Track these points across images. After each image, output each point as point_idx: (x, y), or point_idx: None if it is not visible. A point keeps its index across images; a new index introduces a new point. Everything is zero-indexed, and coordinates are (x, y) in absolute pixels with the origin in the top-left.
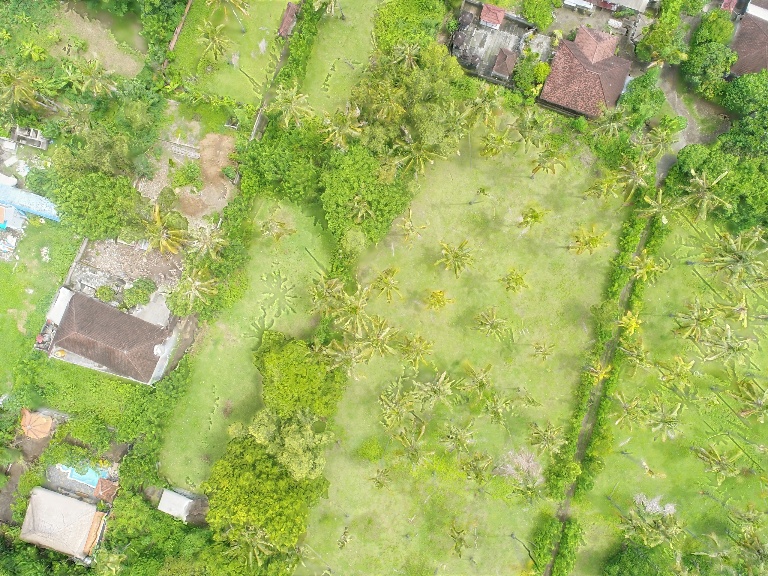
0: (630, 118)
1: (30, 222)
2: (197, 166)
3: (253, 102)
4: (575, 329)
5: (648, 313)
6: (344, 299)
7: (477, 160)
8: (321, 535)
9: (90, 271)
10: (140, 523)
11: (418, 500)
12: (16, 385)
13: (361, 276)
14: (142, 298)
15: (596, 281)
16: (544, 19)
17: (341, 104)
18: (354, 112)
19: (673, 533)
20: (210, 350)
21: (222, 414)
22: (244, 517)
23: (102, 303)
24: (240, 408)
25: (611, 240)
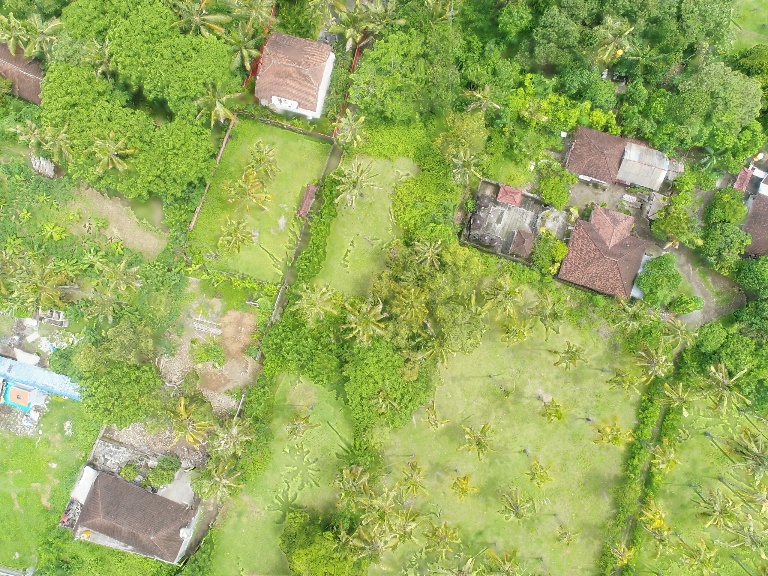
0: (647, 299)
1: (53, 399)
2: None
3: (273, 278)
4: (596, 499)
5: (668, 483)
6: (372, 503)
7: (496, 334)
8: None
9: (114, 447)
10: None
11: None
12: (41, 563)
13: (383, 449)
14: (167, 480)
15: (616, 451)
16: (560, 200)
17: (361, 280)
18: (377, 309)
19: None
20: (234, 522)
21: None
22: None
23: (127, 483)
24: None
25: (630, 411)
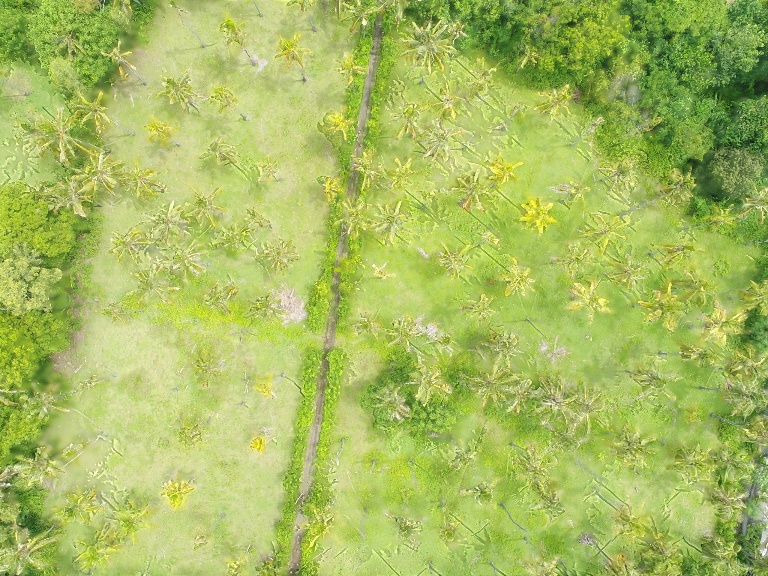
0: None
1: None
2: None
3: None
4: (320, 160)
5: (389, 136)
6: None
7: (206, 3)
8: (91, 399)
9: None
10: None
11: (184, 350)
12: None
13: (102, 129)
14: None
15: (335, 110)
16: None
17: None
18: None
19: (405, 328)
20: None
21: None
22: None
23: None
24: None
25: None
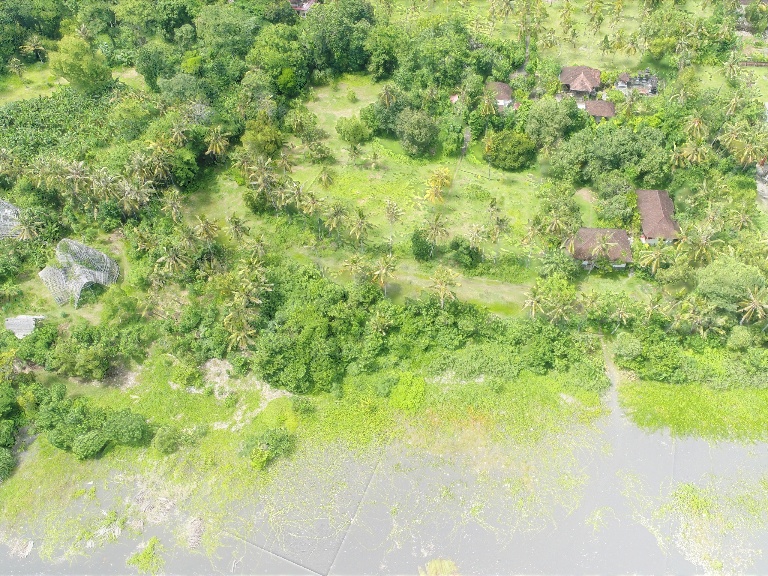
0: None
1: None
2: None
3: None
4: None
5: None
6: None
7: None
8: None
9: None
10: None
11: None
12: None
13: None
14: (750, 4)
15: None
16: None
17: None
18: None
19: None
20: None
21: None
22: None
23: None
24: None
25: None
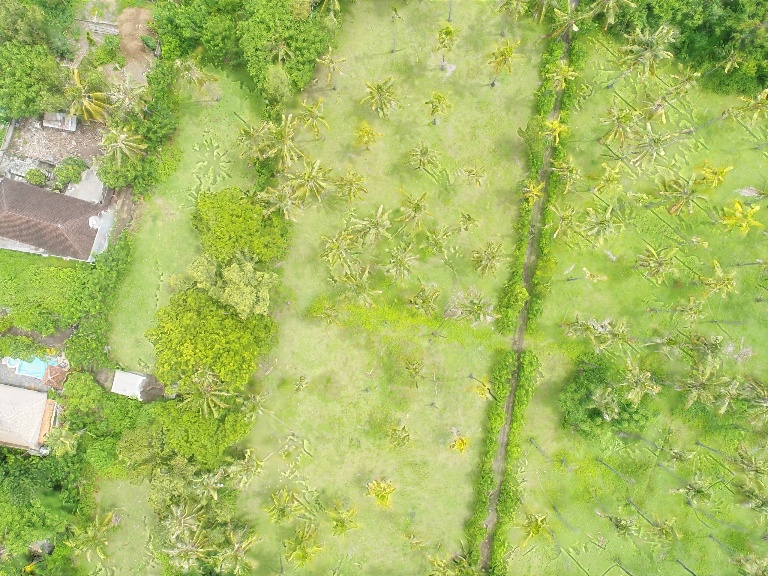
0: None
1: None
2: None
3: None
4: (508, 164)
5: (577, 140)
6: (269, 129)
7: None
8: (281, 401)
9: (18, 158)
10: (93, 401)
11: (374, 352)
12: None
13: None
14: (72, 173)
15: (523, 115)
16: None
17: None
18: None
19: (620, 330)
20: (149, 227)
21: (168, 288)
22: (191, 356)
23: (33, 185)
24: (185, 280)
25: (533, 73)
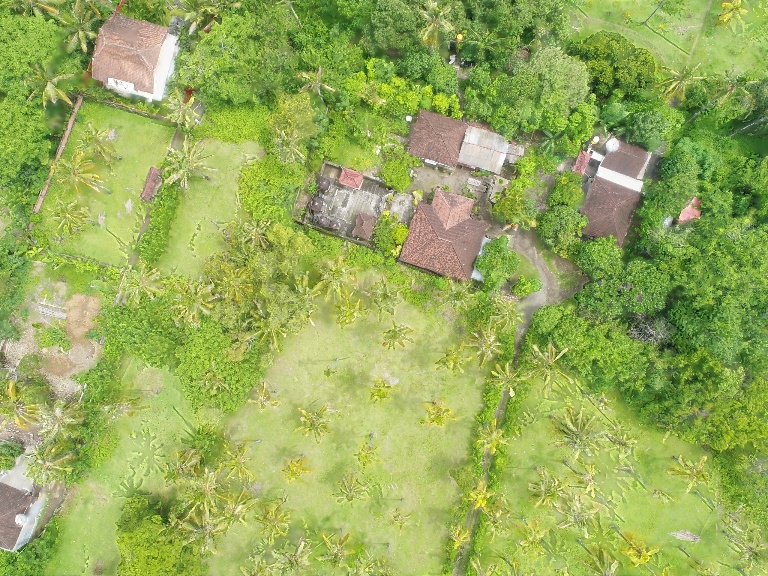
0: None
1: None
2: (60, 331)
3: (120, 261)
4: (443, 483)
5: (514, 466)
6: (190, 484)
7: None
8: None
9: None
10: None
11: None
12: None
13: (229, 434)
14: (4, 466)
15: (462, 435)
16: (401, 183)
17: None
18: (204, 290)
19: None
20: (80, 509)
21: (92, 575)
22: None
23: None
24: (110, 569)
25: (476, 395)
